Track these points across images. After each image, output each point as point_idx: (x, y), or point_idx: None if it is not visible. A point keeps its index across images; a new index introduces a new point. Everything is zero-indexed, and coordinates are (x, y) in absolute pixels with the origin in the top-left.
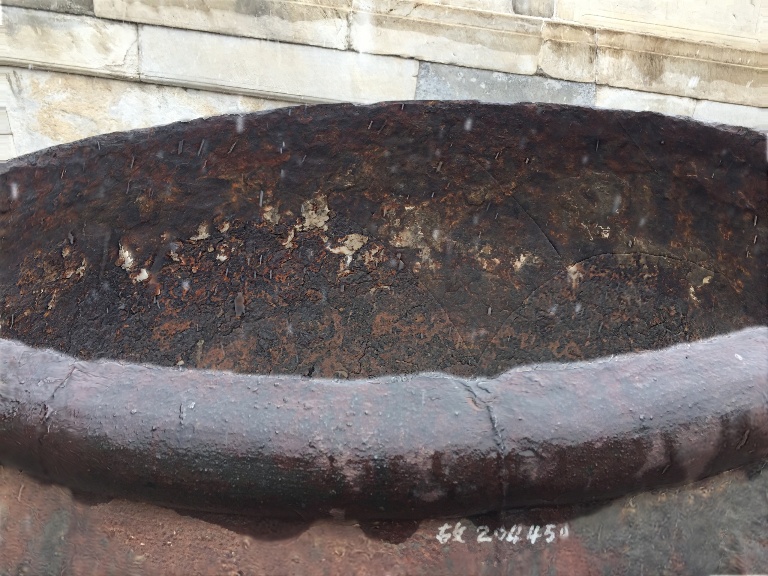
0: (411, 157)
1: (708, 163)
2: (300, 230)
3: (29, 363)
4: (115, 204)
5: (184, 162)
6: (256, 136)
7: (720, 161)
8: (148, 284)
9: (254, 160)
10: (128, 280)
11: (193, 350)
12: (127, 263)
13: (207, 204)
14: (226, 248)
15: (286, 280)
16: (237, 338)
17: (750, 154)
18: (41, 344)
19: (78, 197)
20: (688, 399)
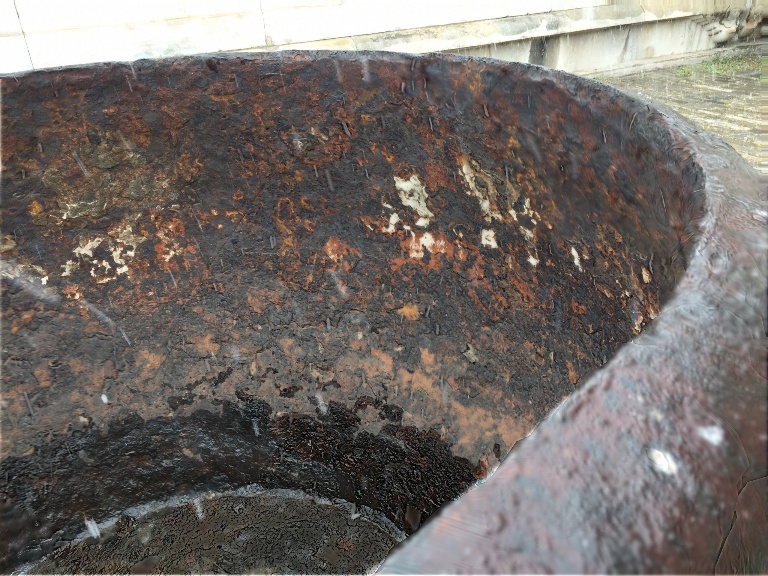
0: None
1: None
2: None
3: None
4: None
5: None
6: None
7: None
8: None
9: None
10: None
11: None
12: None
13: None
14: None
15: None
16: None
17: None
18: None
19: None
20: None
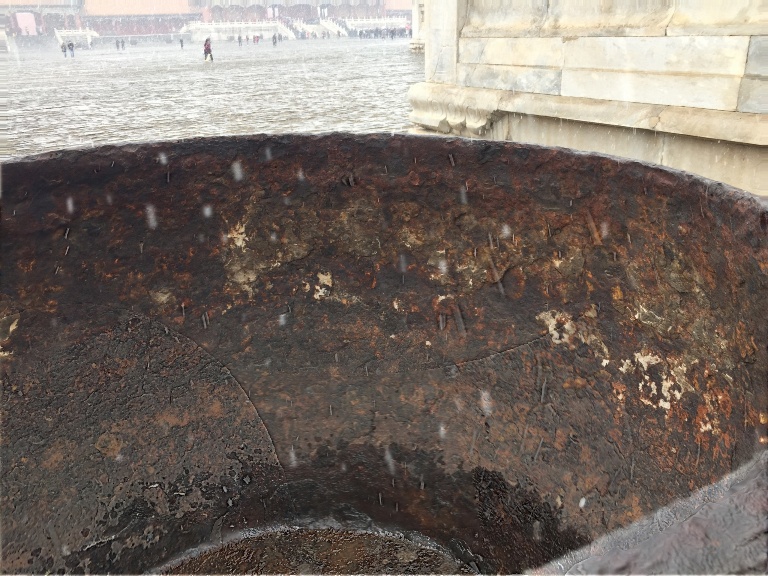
0: None
1: (7, 203)
2: None
3: (731, 187)
4: None
5: None
6: None
7: (26, 194)
8: None
9: None
10: None
11: None
12: None
13: None
14: None
15: None
16: None
17: (71, 172)
18: None
19: None
20: None
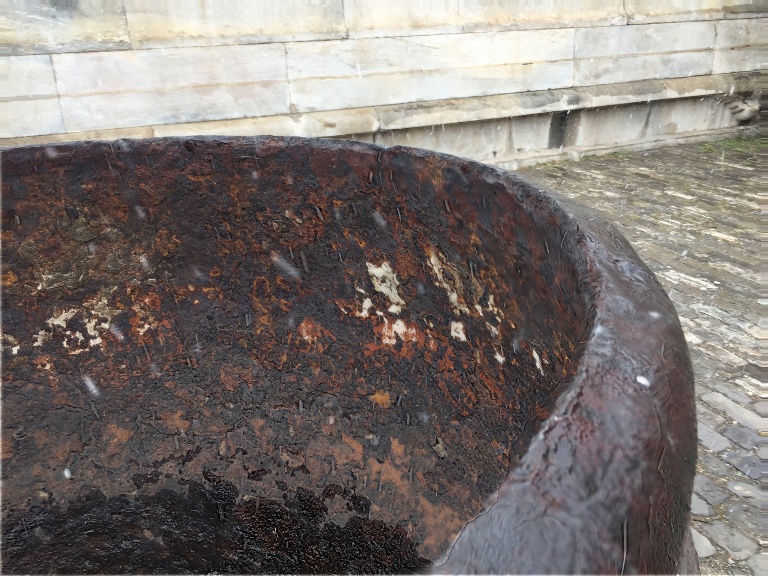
0: None
1: None
2: None
3: None
4: None
5: None
6: None
7: None
8: None
9: None
10: None
11: None
12: None
13: None
14: None
15: None
16: None
17: None
18: None
19: None
20: None
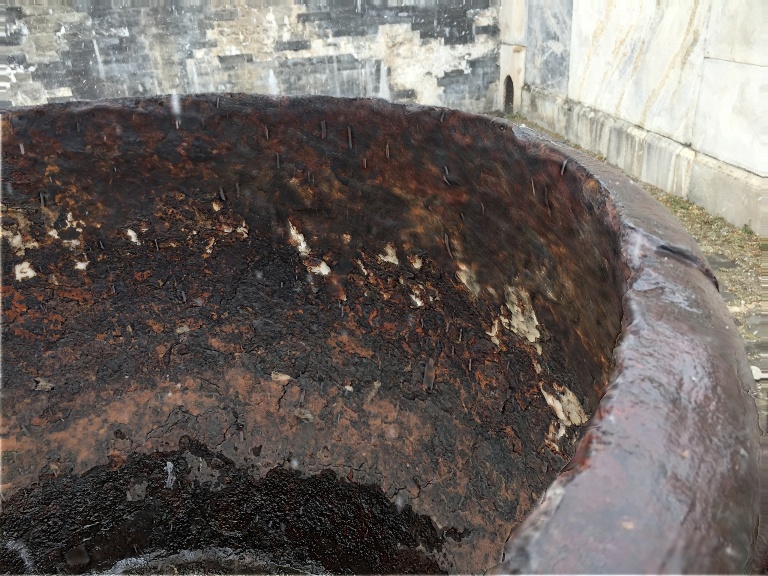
0: (605, 303)
1: None
2: (507, 327)
3: None
4: (271, 175)
5: (335, 151)
6: (410, 143)
7: None
8: (332, 282)
9: (424, 181)
10: (303, 265)
11: (368, 386)
12: (303, 247)
13: (393, 220)
14: (423, 291)
15: (486, 387)
16: (415, 412)
17: None
18: (199, 279)
19: (216, 154)
20: None
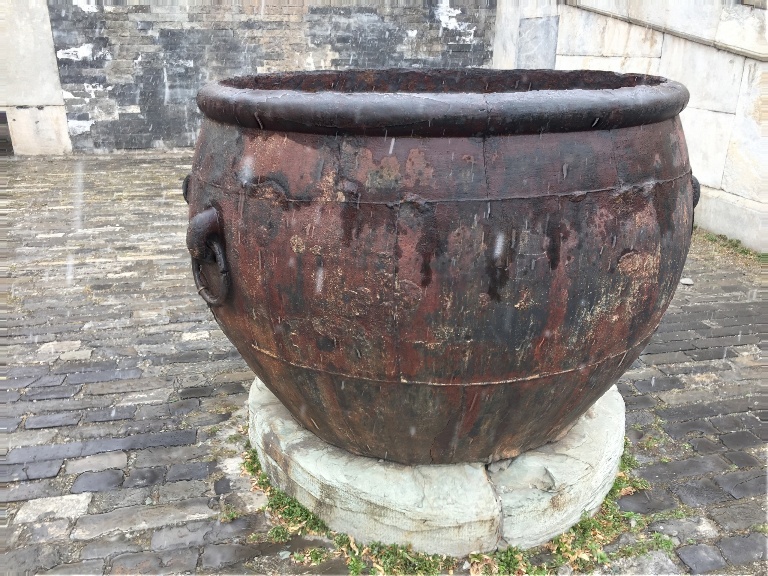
0: None
1: None
2: None
3: None
4: None
5: None
6: (562, 87)
7: None
8: None
9: None
10: None
11: None
12: None
13: None
14: None
15: None
16: None
17: None
18: None
19: None
20: (209, 92)
